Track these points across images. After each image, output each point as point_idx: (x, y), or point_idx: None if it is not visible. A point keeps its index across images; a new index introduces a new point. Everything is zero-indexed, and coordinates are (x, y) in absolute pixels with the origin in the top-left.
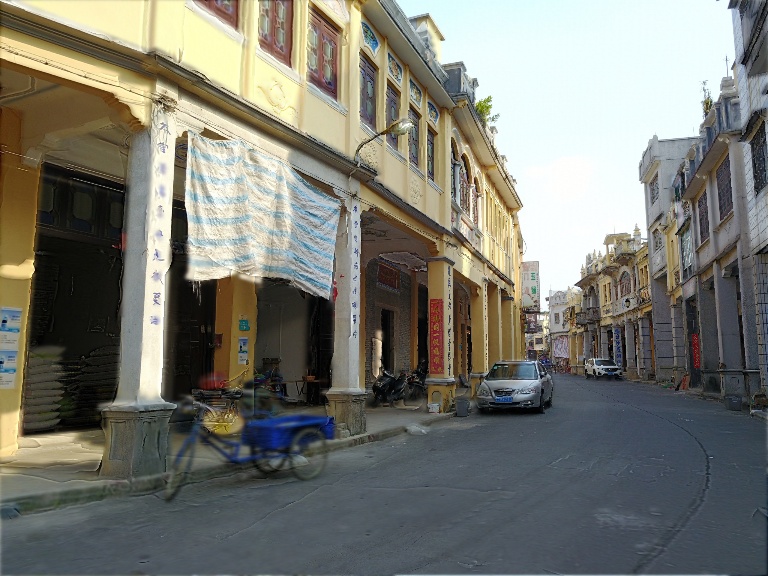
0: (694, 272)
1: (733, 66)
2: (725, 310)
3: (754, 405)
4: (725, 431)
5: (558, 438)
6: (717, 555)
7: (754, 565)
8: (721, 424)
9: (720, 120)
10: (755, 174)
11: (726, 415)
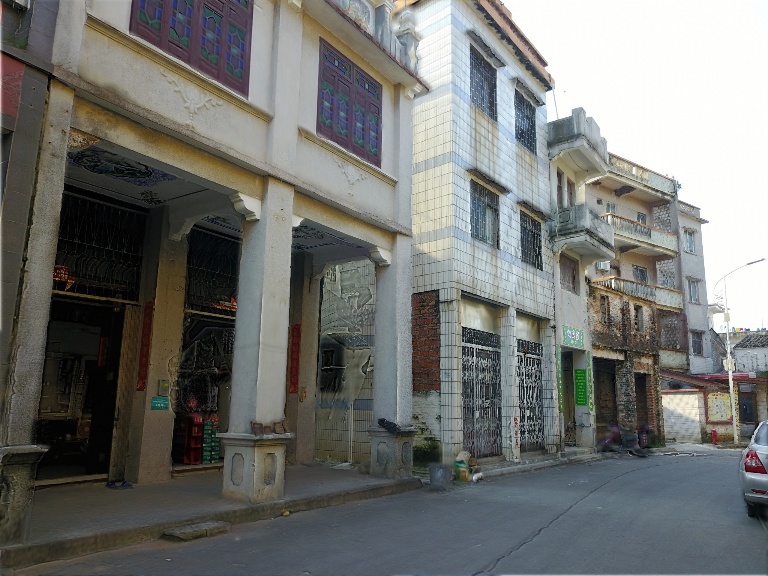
0: (75, 74)
1: None
2: None
3: None
4: (592, 473)
5: None
6: None
7: None
8: None
9: None
10: None
11: None
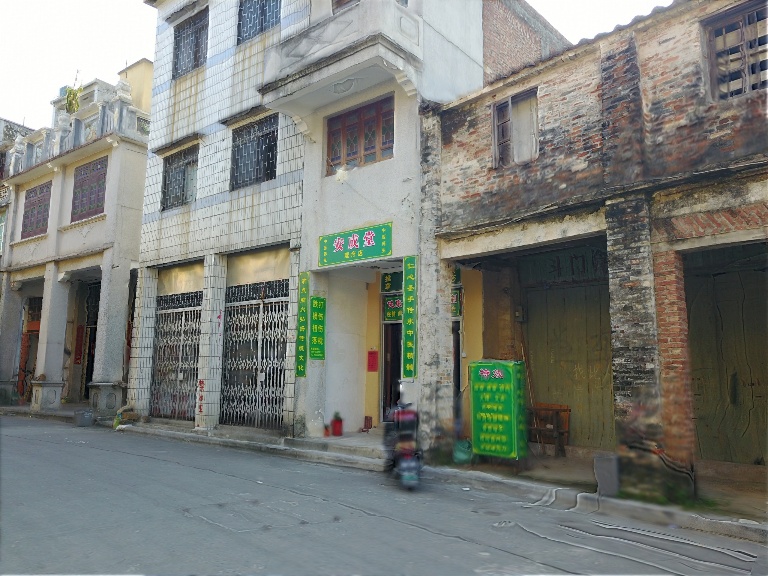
0: (3, 268)
1: (123, 72)
2: (55, 316)
3: (125, 420)
4: (158, 451)
5: (65, 488)
6: (617, 575)
7: (645, 573)
8: (125, 443)
9: (104, 119)
10: (164, 190)
11: (90, 432)
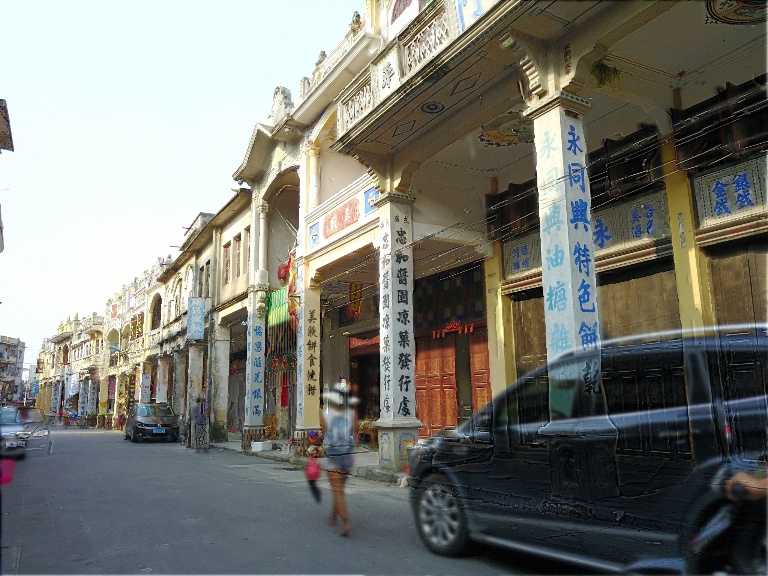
0: None
1: None
2: None
3: None
4: None
5: None
6: None
7: None
8: None
9: None
10: None
11: None
